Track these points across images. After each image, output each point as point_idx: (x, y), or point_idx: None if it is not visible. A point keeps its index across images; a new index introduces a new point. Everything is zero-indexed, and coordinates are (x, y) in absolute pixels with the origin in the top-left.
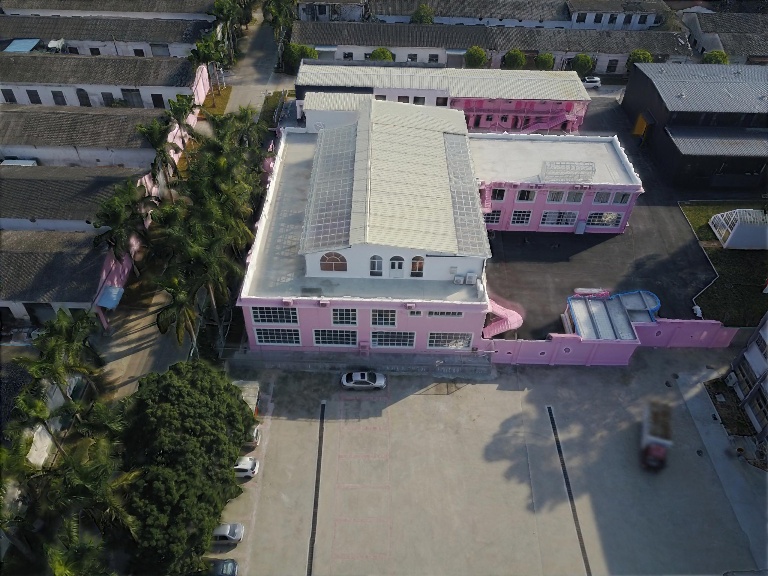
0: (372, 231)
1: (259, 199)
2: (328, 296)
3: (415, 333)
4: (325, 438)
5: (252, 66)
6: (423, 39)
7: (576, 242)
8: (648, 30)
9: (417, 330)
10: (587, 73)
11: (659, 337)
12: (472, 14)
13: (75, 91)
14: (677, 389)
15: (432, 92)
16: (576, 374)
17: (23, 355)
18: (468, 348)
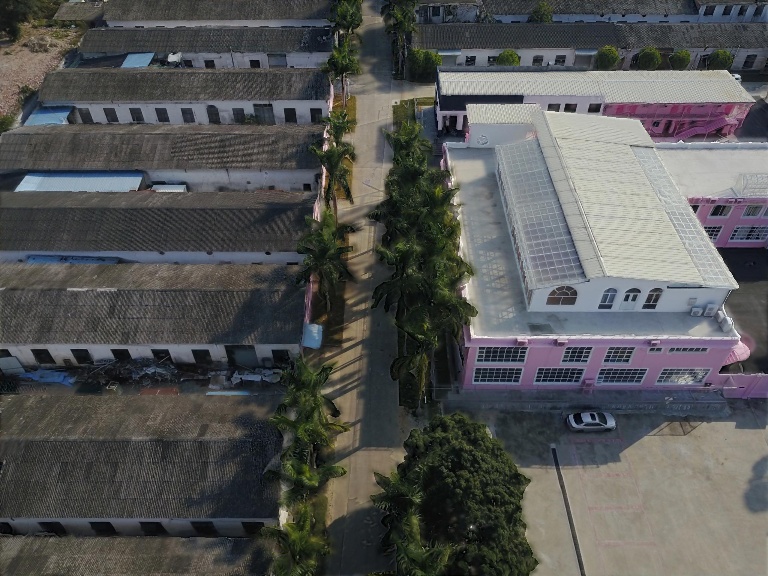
0: (607, 262)
1: None
2: (561, 333)
3: (647, 369)
4: (567, 487)
5: (370, 73)
6: (550, 39)
7: None
8: None
9: (650, 366)
10: None
11: None
12: (593, 10)
13: (205, 108)
14: None
15: (586, 98)
16: None
17: (251, 407)
18: (700, 383)
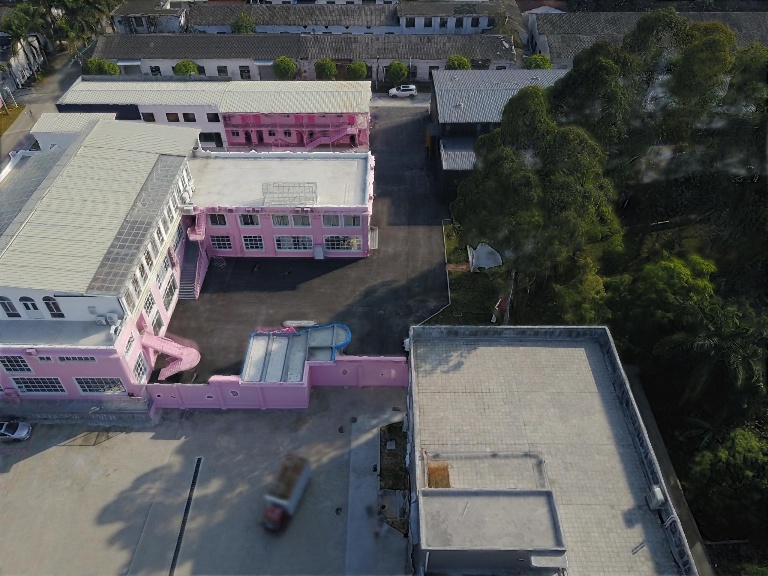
0: None
1: None
2: None
3: (59, 379)
4: None
5: (58, 83)
6: (232, 50)
7: (313, 268)
8: None
9: (59, 376)
10: (402, 81)
11: (346, 376)
12: (296, 22)
13: None
14: (348, 435)
15: (200, 108)
16: (246, 419)
17: None
18: (125, 393)
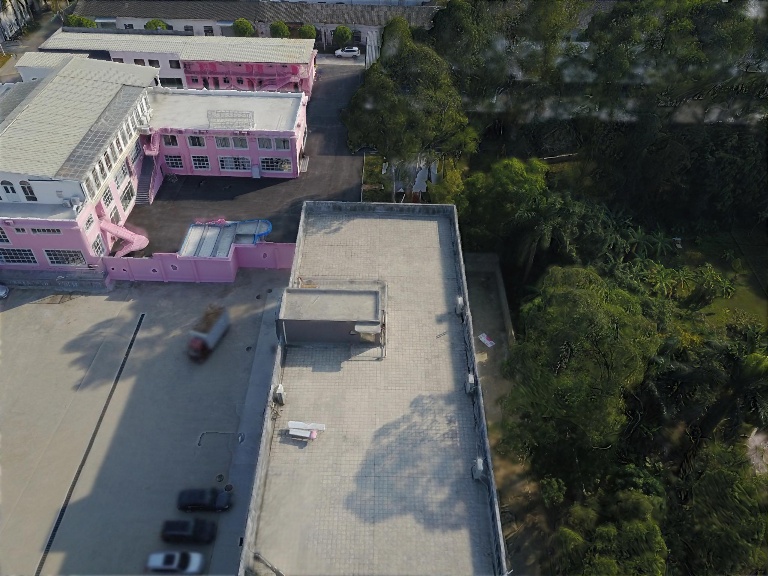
0: None
1: None
2: None
3: (31, 250)
4: None
5: (42, 37)
6: (197, 12)
7: (250, 185)
8: None
9: (32, 247)
10: (347, 43)
11: (266, 259)
12: None
13: None
14: (264, 301)
15: (163, 55)
16: (183, 289)
17: None
18: (86, 265)
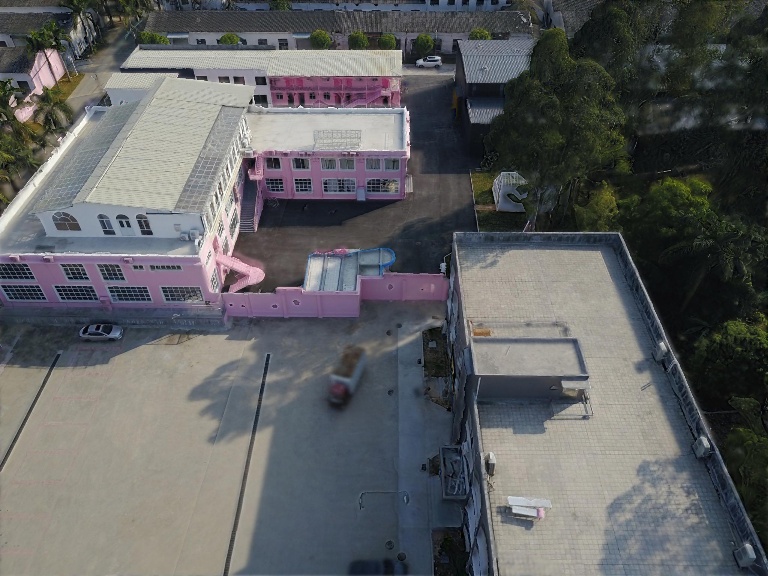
0: (97, 192)
1: (27, 169)
2: None
3: (147, 287)
4: (48, 383)
5: (112, 55)
6: (272, 24)
7: (356, 208)
8: (499, 10)
9: (148, 284)
10: (429, 53)
11: (392, 290)
12: None
13: None
14: (395, 337)
15: (249, 72)
16: (306, 325)
17: None
18: (203, 302)
